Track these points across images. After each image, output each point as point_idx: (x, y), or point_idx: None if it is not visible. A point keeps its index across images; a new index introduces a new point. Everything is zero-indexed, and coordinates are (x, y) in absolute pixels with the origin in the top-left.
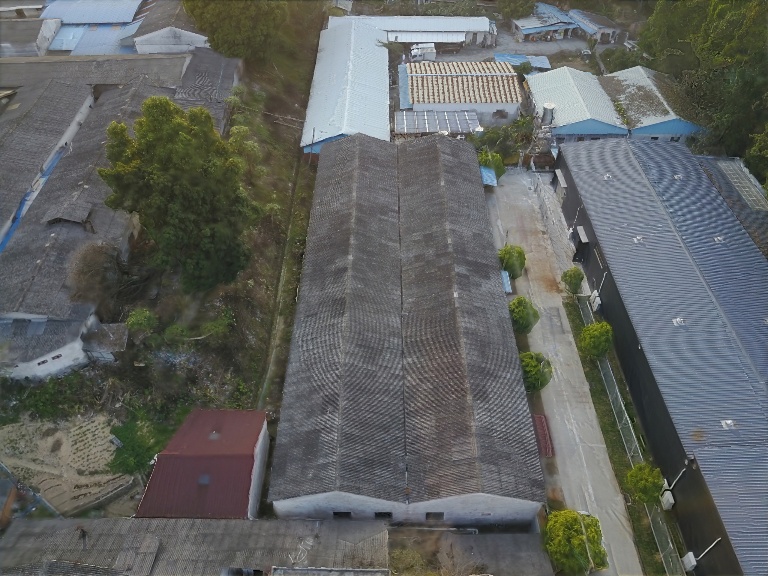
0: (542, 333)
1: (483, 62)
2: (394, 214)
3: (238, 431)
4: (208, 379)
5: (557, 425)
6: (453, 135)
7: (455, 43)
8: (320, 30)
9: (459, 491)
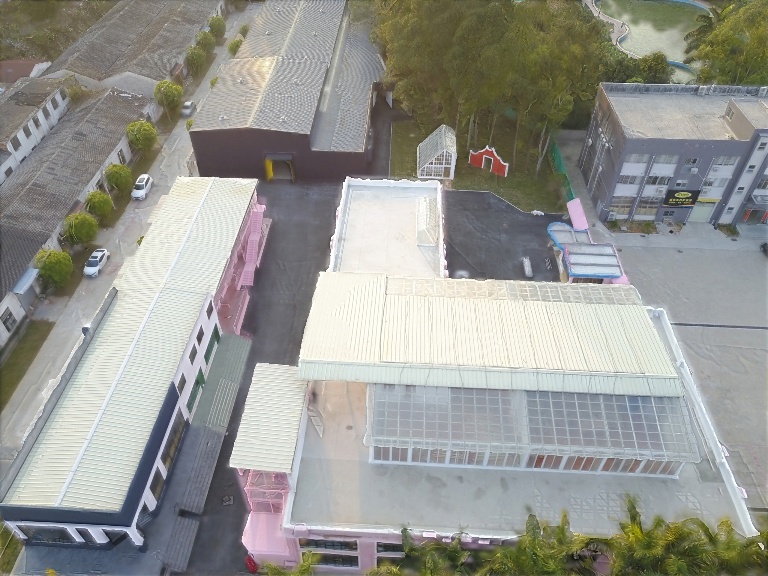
0: (224, 58)
1: None
2: (162, 5)
3: (33, 61)
4: (32, 57)
5: (205, 84)
6: None
7: None
8: None
9: (120, 72)
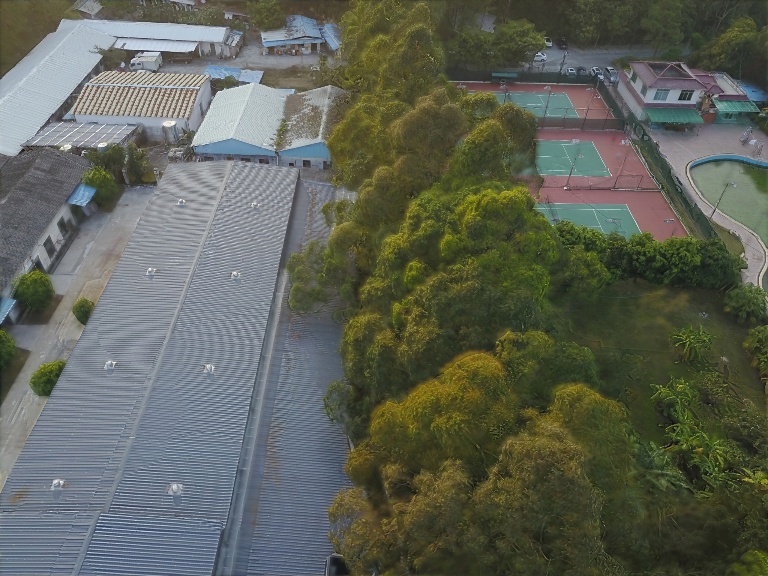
0: None
1: (184, 74)
2: None
3: None
4: None
5: None
6: (78, 150)
7: (184, 53)
8: (49, 33)
9: None
